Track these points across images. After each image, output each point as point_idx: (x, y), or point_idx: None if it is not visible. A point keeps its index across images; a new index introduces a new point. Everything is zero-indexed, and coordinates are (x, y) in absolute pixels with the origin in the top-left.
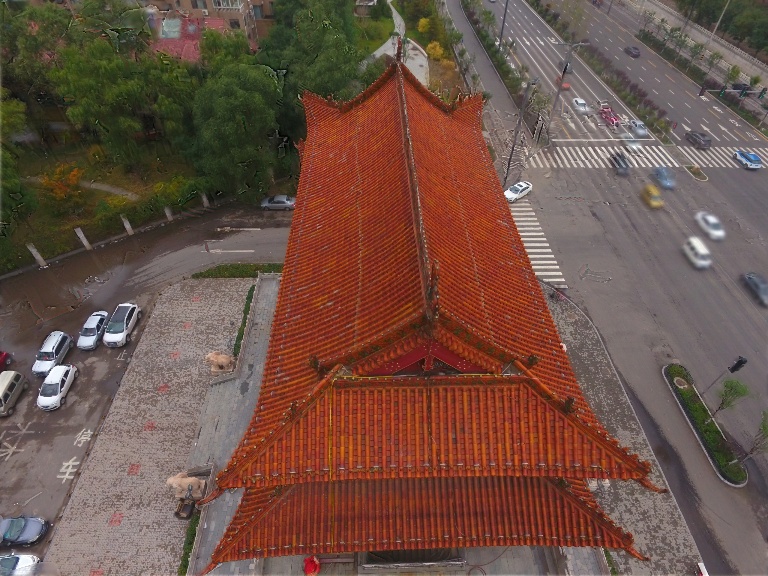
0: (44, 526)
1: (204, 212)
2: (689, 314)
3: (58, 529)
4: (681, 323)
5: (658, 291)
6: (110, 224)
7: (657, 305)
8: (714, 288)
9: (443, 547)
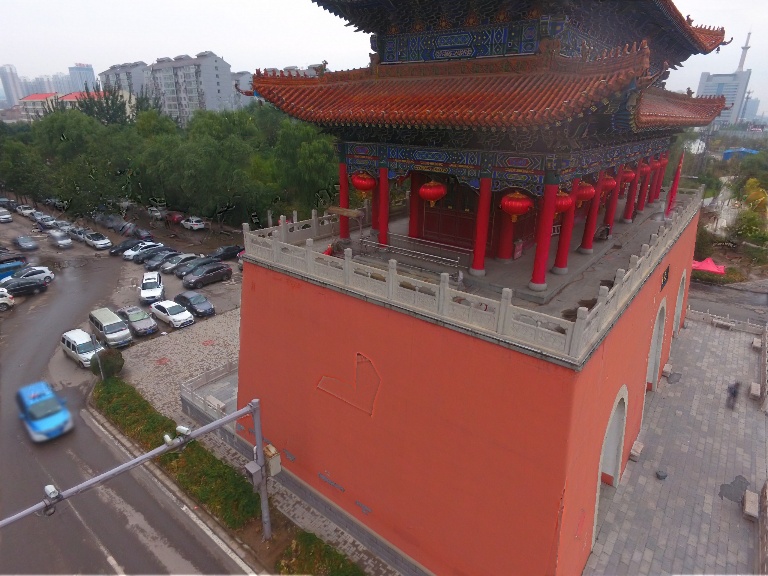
0: (211, 309)
1: None
2: None
3: (216, 317)
4: None
5: None
6: None
7: None
8: None
9: (419, 121)
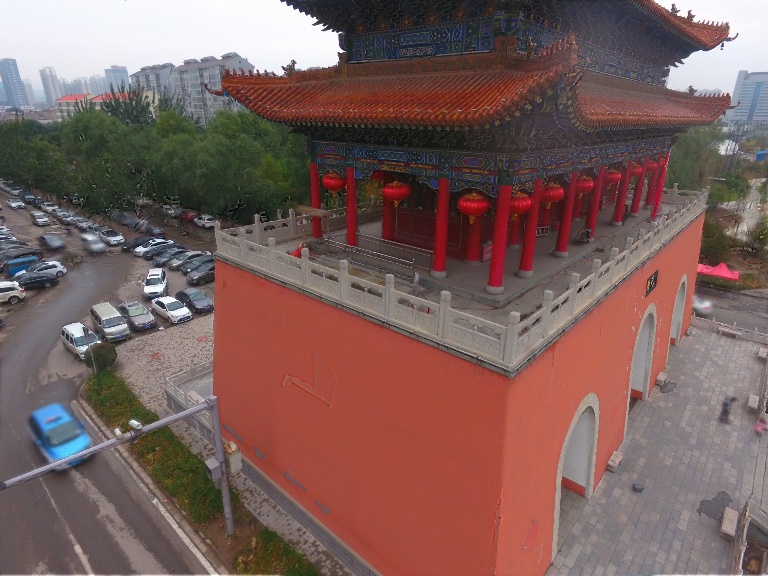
0: (210, 306)
1: None
2: None
3: None
4: None
5: None
6: None
7: None
8: None
9: (371, 120)
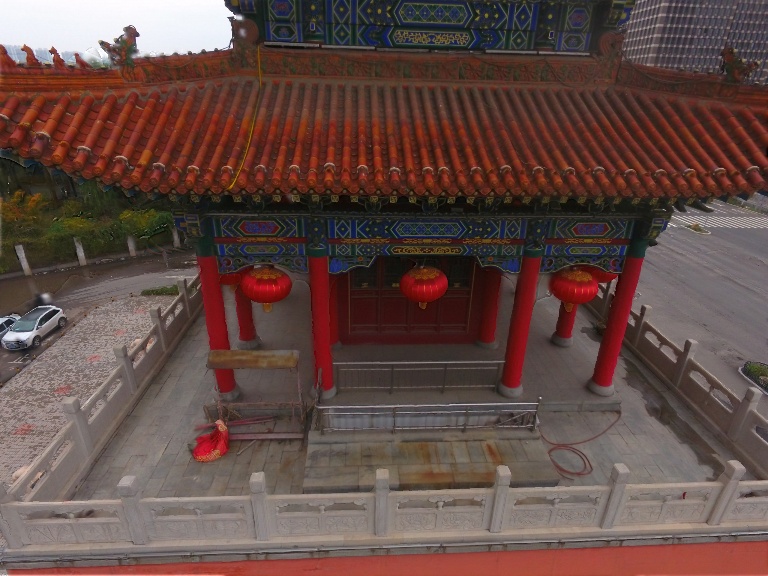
0: None
1: (173, 251)
2: (745, 324)
3: None
4: (740, 331)
5: (699, 306)
6: (60, 247)
7: (703, 317)
8: (762, 304)
9: (501, 189)
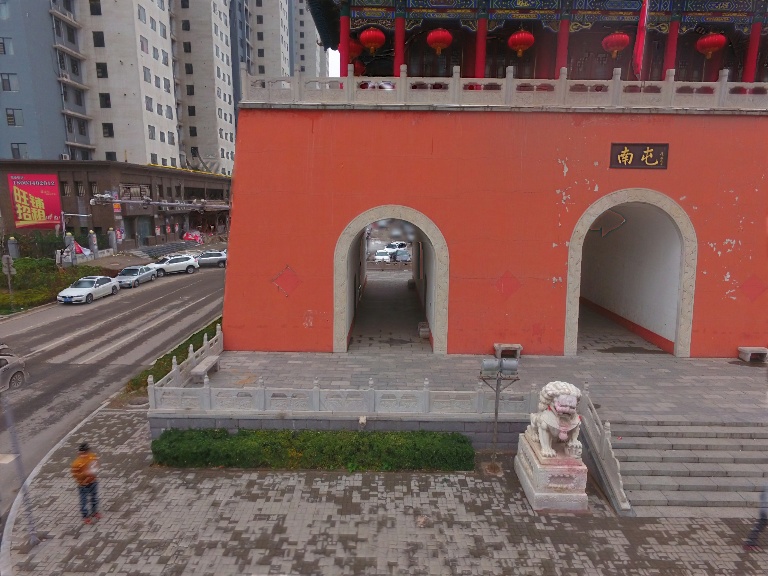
0: None
1: None
2: None
3: None
4: None
5: None
6: None
7: None
8: None
9: None
